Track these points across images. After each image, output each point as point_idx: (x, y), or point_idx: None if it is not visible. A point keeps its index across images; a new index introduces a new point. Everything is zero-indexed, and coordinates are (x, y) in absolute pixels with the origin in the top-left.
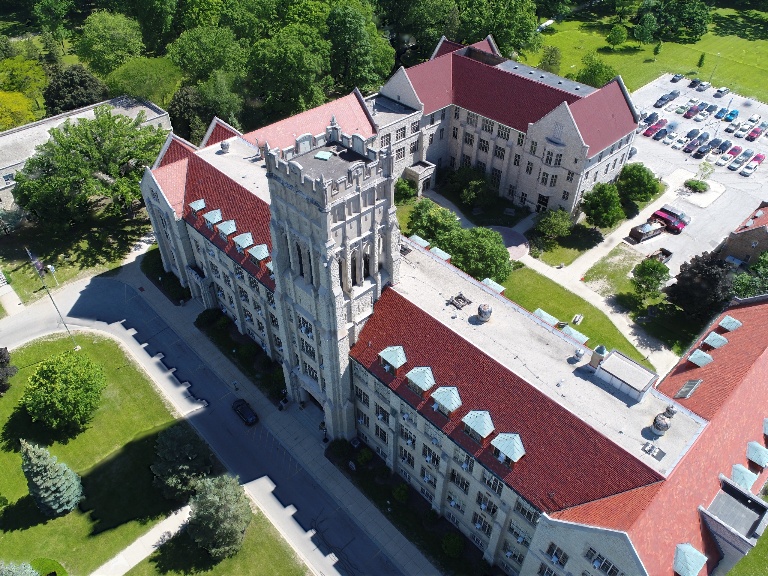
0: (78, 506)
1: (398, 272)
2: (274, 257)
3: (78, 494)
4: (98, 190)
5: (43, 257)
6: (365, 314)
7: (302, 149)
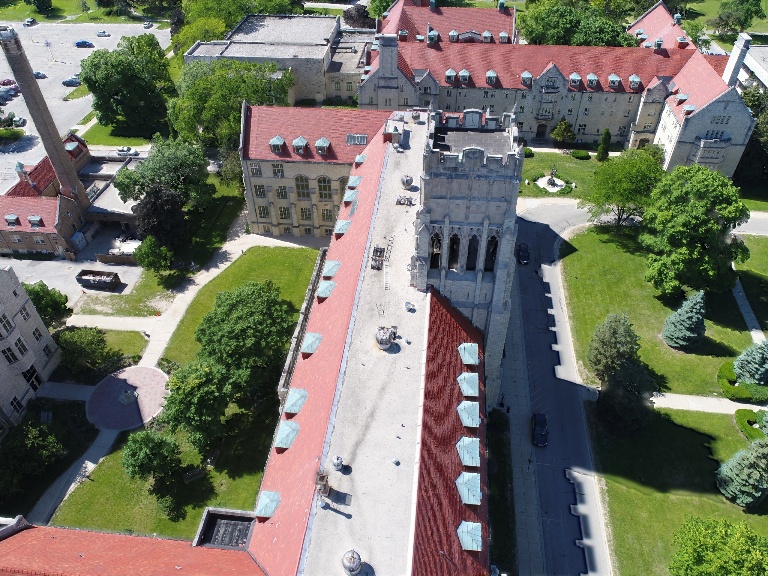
0: None
1: None
2: None
3: None
4: None
5: None
6: None
7: None
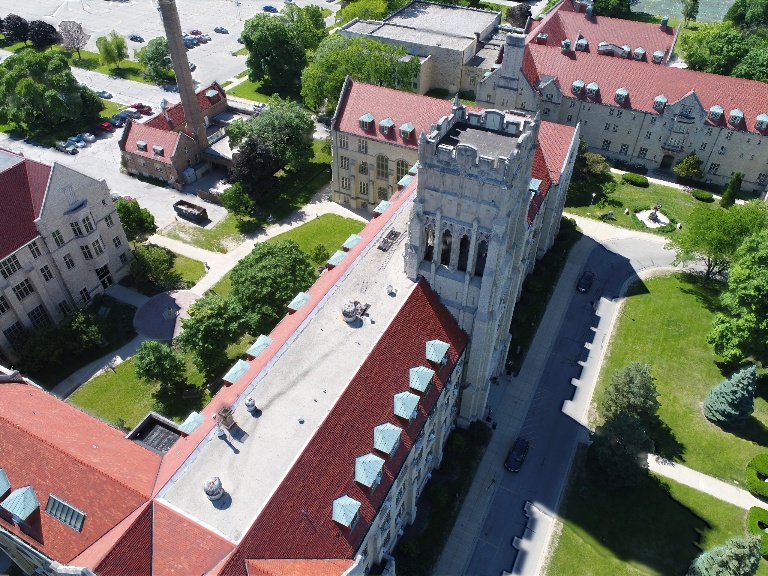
0: None
1: None
2: None
3: None
4: None
5: None
6: None
7: None
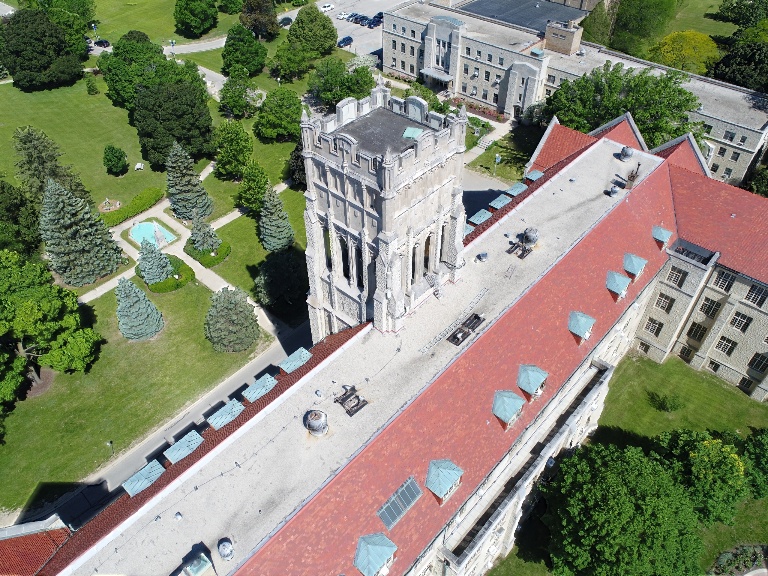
0: (271, 253)
1: (381, 319)
2: None
3: (275, 247)
4: (574, 129)
5: (523, 155)
6: (347, 319)
7: (412, 113)
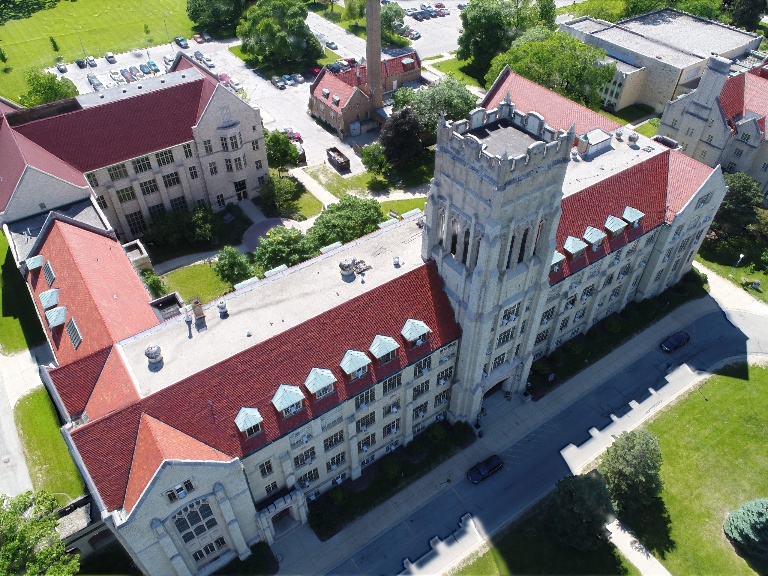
0: None
1: None
2: (497, 275)
3: None
4: None
5: None
6: None
7: None
